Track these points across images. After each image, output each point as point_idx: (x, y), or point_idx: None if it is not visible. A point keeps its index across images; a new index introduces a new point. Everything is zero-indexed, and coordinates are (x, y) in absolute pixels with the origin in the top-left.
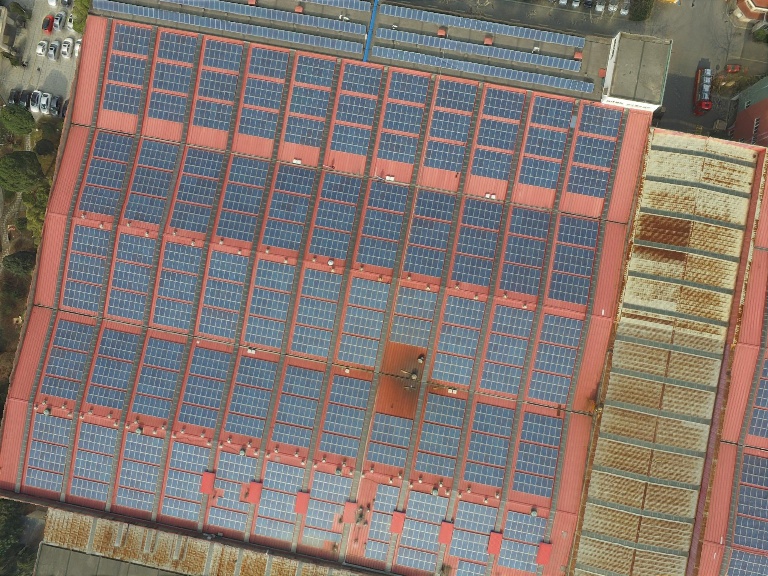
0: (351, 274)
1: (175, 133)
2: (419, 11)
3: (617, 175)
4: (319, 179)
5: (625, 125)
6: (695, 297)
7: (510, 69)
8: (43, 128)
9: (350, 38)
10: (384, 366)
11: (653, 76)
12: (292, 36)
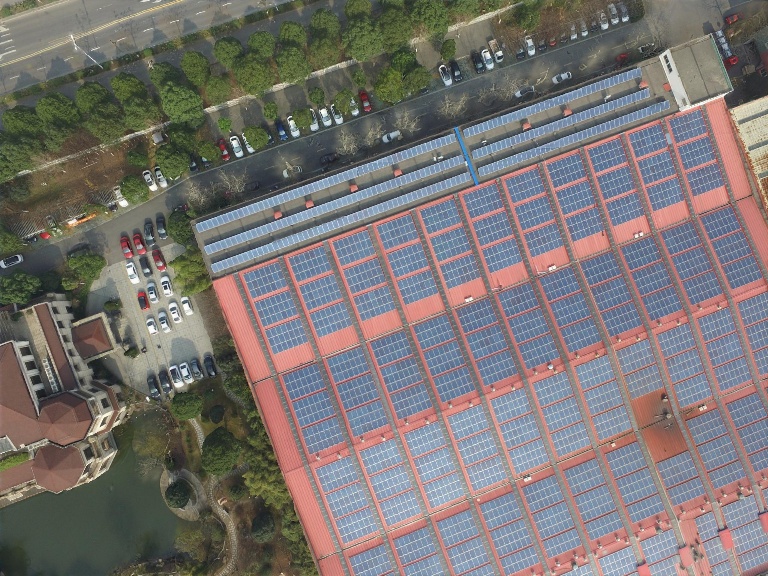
0: (571, 365)
1: (350, 337)
2: (498, 118)
3: (723, 161)
4: (496, 303)
5: (708, 119)
6: None
7: (598, 125)
8: (208, 399)
9: (452, 172)
10: (639, 422)
11: (712, 70)
12: (405, 198)
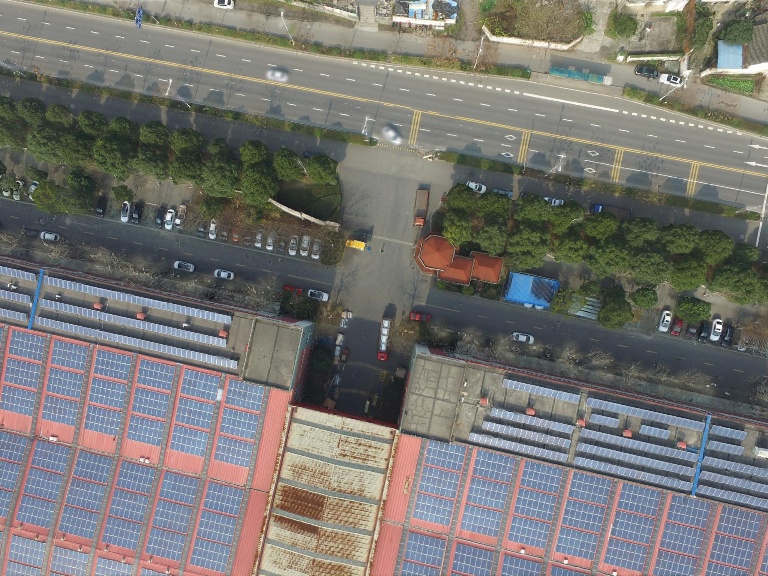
0: (11, 531)
1: None
2: (79, 284)
3: (261, 446)
4: None
5: (267, 400)
6: (327, 569)
7: (160, 344)
8: None
9: (18, 305)
10: None
11: (285, 361)
12: None
